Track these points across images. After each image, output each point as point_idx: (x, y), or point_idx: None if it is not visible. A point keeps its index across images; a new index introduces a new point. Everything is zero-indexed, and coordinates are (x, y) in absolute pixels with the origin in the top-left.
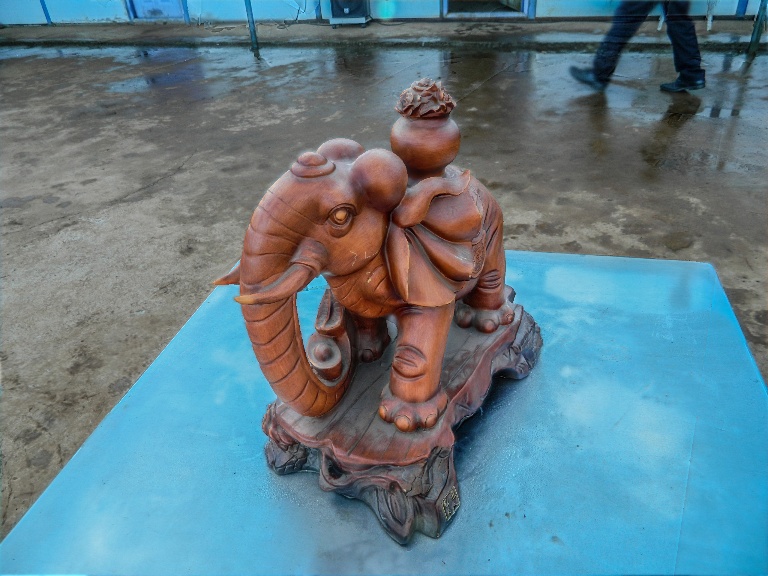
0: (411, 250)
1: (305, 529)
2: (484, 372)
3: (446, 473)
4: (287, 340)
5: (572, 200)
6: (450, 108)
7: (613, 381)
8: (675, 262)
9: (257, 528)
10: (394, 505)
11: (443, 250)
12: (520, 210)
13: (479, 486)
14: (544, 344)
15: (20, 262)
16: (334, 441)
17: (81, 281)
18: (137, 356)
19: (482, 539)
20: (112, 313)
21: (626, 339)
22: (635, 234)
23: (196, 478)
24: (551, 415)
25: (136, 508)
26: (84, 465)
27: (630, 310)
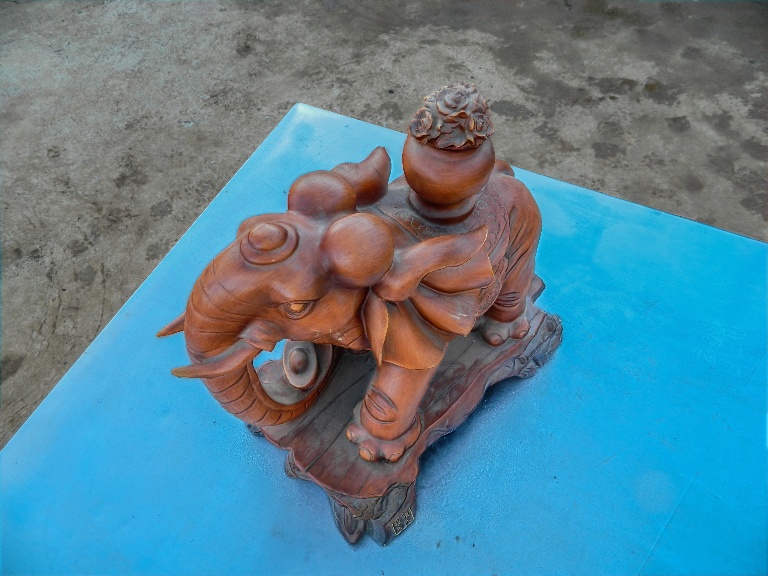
0: (395, 312)
1: (266, 502)
2: (474, 393)
3: (403, 499)
4: (240, 390)
5: (704, 53)
6: (481, 140)
7: (624, 405)
8: (767, 247)
9: (224, 489)
10: (345, 517)
11: (437, 309)
12: (634, 58)
13: (440, 499)
14: (566, 337)
15: (74, 34)
16: (296, 452)
17: (133, 71)
18: (180, 178)
19: (425, 559)
20: (160, 119)
21: (661, 351)
22: (763, 120)
23: (179, 418)
24: (541, 433)
25: (122, 437)
26: (83, 376)
27: (682, 310)
